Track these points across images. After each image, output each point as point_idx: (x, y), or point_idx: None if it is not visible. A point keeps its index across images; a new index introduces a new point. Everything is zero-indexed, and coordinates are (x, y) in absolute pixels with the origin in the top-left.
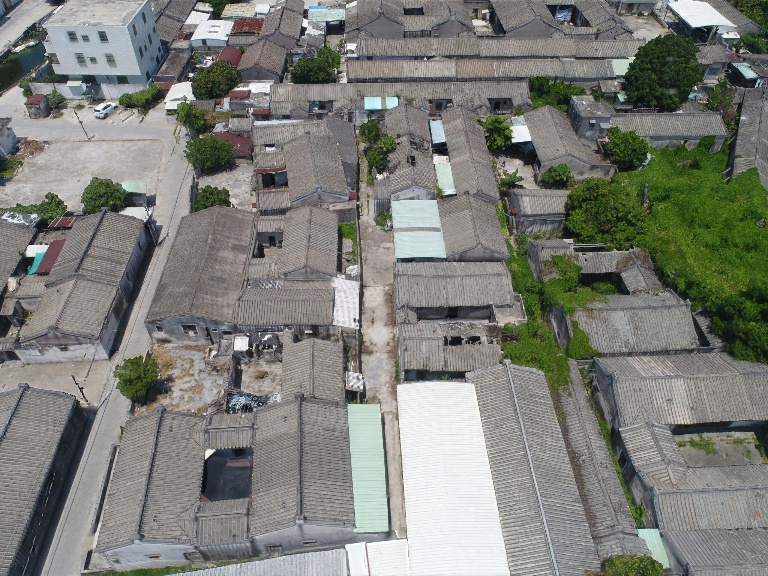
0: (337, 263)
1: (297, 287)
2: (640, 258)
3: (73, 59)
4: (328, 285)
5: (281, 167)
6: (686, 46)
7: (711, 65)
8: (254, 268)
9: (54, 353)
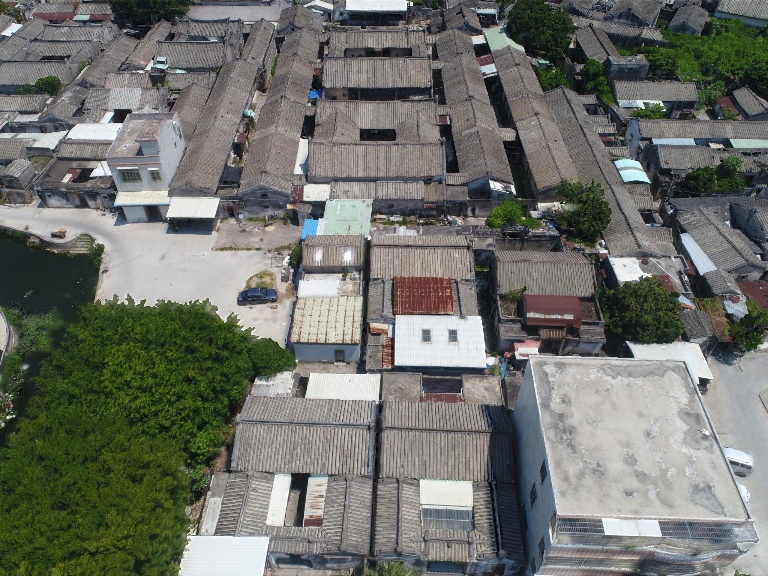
0: None
1: None
2: None
3: None
4: None
5: None
6: (542, 1)
7: None
8: None
9: None
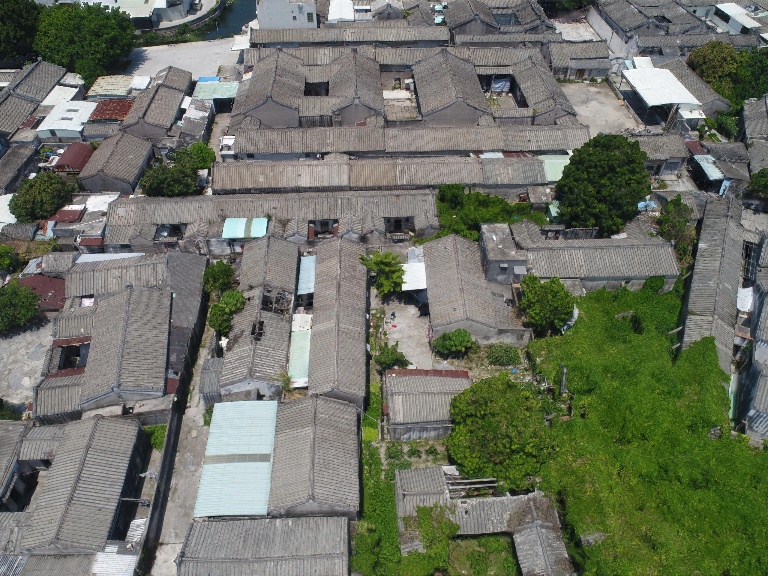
0: (115, 519)
1: (42, 572)
2: (542, 509)
3: None
4: (89, 566)
5: (90, 335)
6: (630, 153)
7: (668, 159)
8: None
9: None
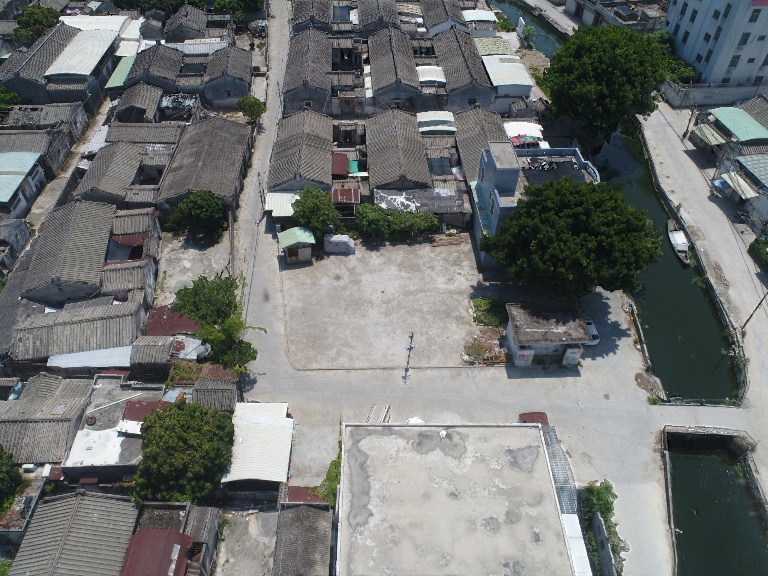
0: None
1: None
2: None
3: None
4: None
5: None
6: None
7: None
8: None
9: None
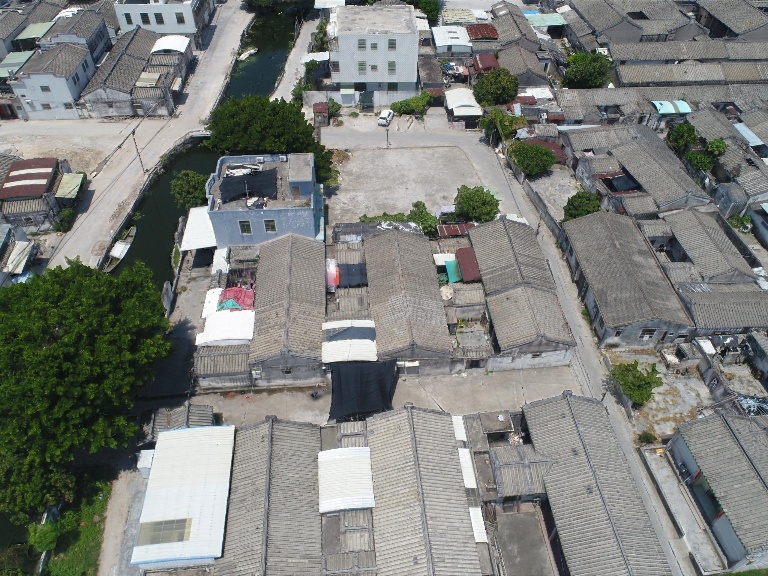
0: None
1: (726, 290)
2: None
3: (354, 67)
4: (754, 287)
5: (616, 172)
6: None
7: None
8: (675, 272)
9: (523, 360)
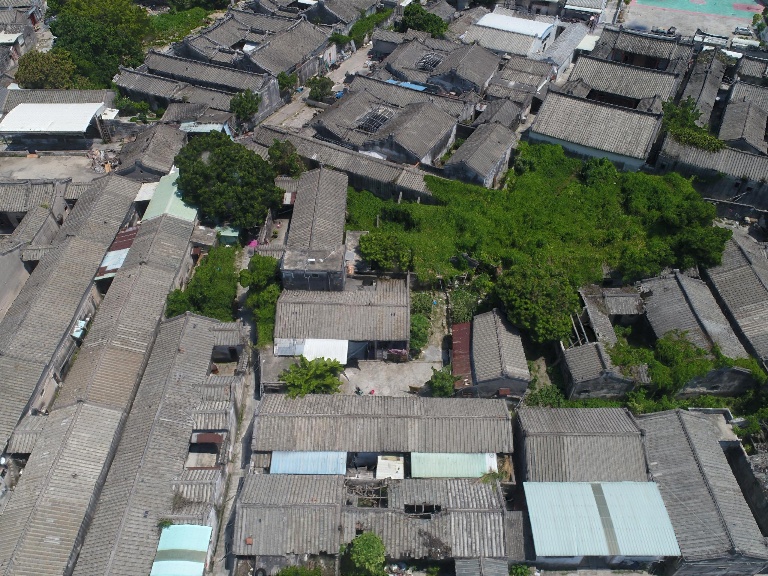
0: None
1: None
2: (592, 291)
3: None
4: None
5: None
6: (226, 140)
7: None
8: None
9: None
